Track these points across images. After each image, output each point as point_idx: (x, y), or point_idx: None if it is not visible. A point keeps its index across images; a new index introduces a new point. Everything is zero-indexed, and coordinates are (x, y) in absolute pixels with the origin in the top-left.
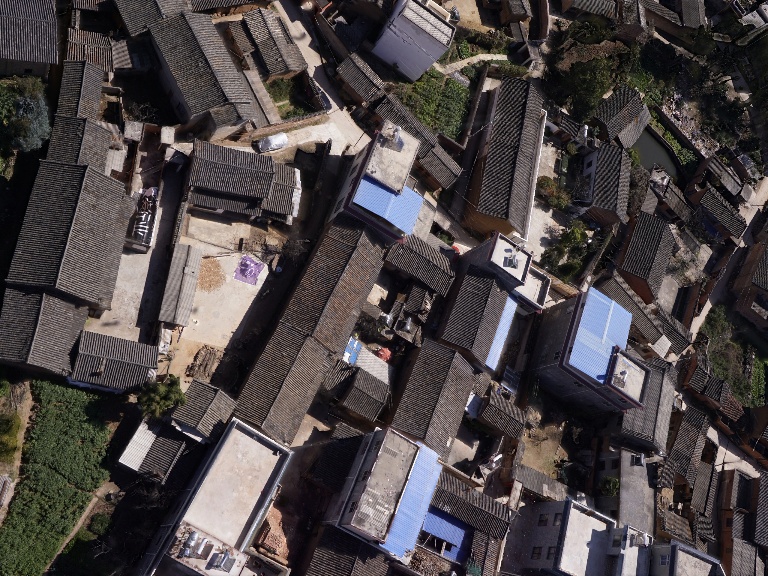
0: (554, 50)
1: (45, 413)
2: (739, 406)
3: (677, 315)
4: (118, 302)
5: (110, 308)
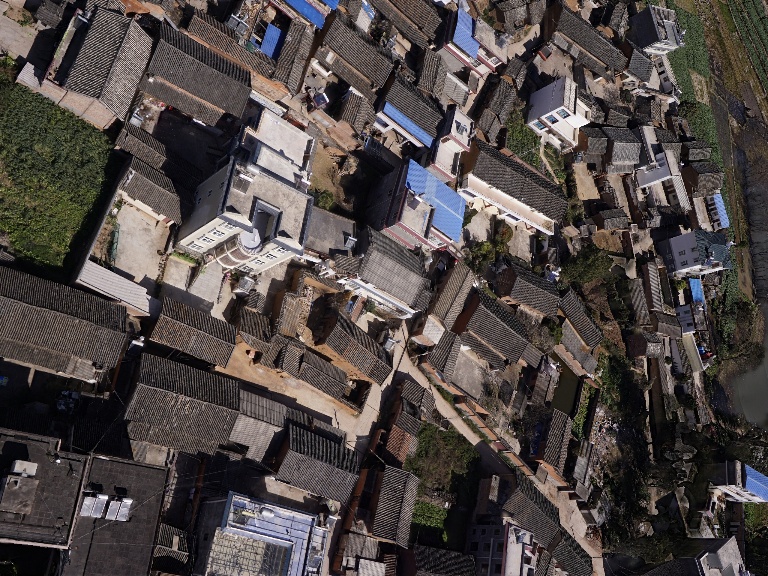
0: None
1: None
2: (402, 455)
3: None
4: None
5: None
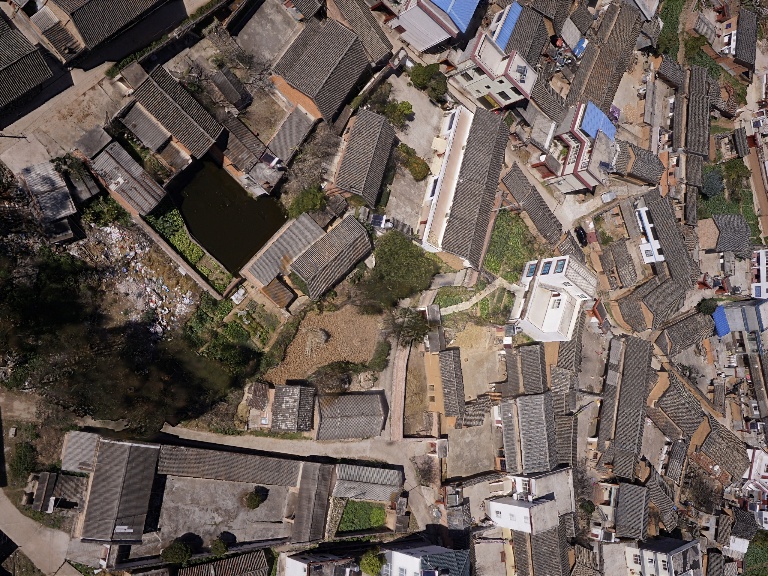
0: (385, 338)
1: (676, 57)
2: None
3: (254, 4)
4: (659, 104)
5: (677, 93)
